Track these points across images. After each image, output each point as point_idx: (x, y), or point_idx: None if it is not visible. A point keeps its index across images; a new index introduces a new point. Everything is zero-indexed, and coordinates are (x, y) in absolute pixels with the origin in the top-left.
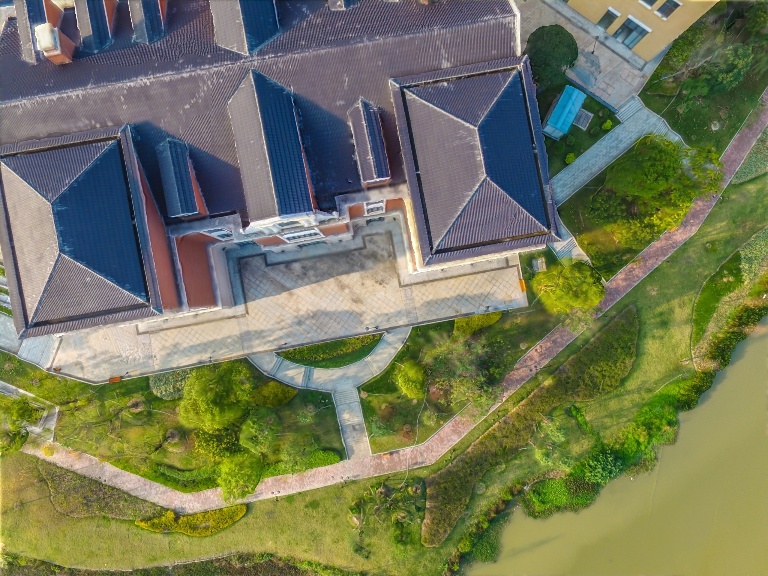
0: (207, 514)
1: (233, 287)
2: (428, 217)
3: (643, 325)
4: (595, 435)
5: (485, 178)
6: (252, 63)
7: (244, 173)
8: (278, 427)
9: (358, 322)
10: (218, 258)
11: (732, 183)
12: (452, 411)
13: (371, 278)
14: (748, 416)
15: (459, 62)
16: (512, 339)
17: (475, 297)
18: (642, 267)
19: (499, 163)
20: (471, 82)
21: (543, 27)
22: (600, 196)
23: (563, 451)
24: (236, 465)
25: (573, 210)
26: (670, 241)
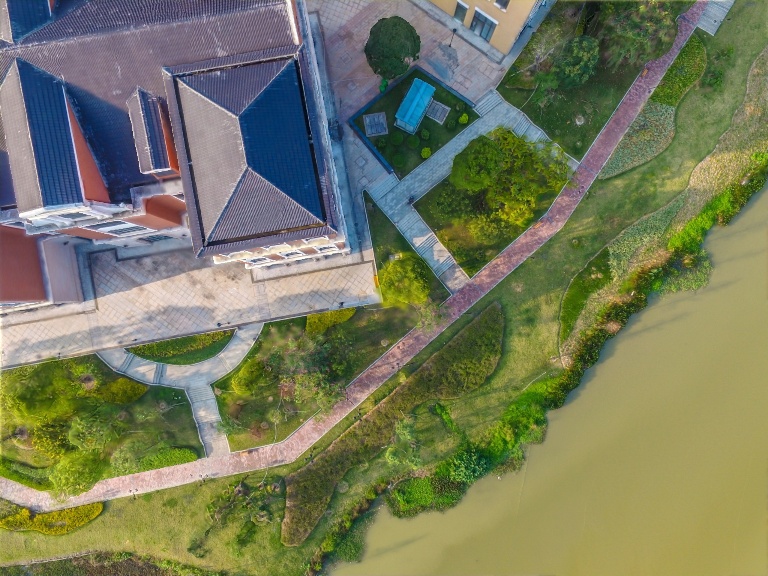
0: (63, 512)
1: (83, 282)
2: (200, 208)
3: (509, 322)
4: (461, 433)
5: (247, 168)
6: (16, 51)
7: (13, 163)
8: (129, 424)
9: (210, 318)
10: (57, 252)
11: (599, 178)
12: (312, 409)
13: (223, 273)
14: (618, 415)
15: (235, 51)
16: (371, 336)
17: (329, 293)
18: (507, 263)
19: (264, 153)
20: (244, 71)
21: (383, 19)
22: (444, 190)
23: (428, 450)
24: (69, 462)
25: (431, 205)
26: (535, 237)
